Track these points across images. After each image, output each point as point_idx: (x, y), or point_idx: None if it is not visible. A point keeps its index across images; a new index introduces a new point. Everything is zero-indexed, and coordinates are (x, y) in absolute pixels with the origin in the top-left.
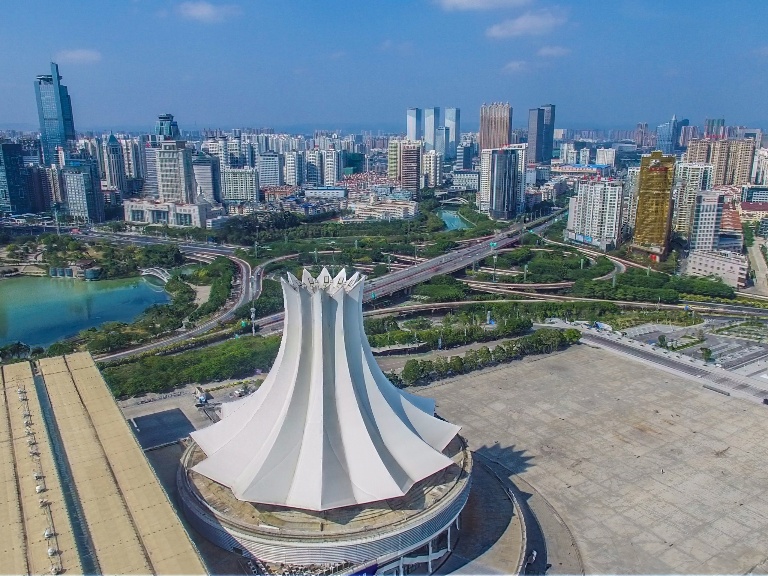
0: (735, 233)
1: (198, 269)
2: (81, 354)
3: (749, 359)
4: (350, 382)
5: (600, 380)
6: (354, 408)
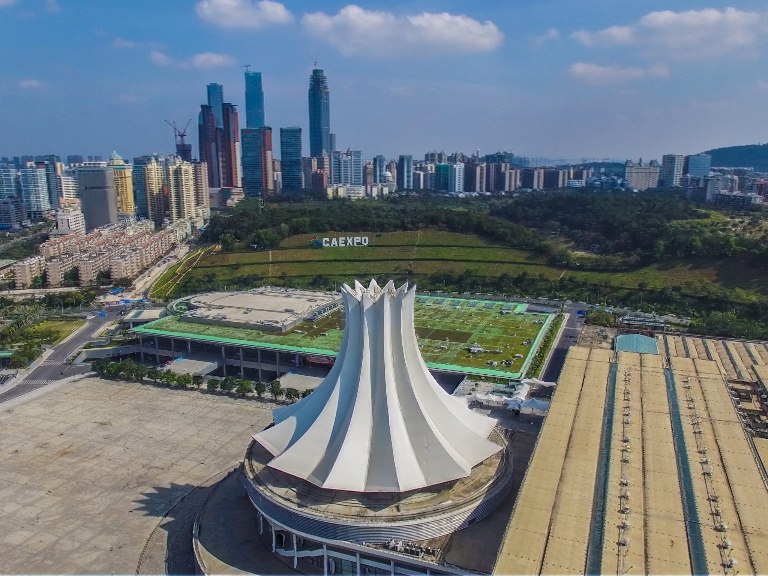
0: None
1: None
2: None
3: None
4: None
5: None
6: None
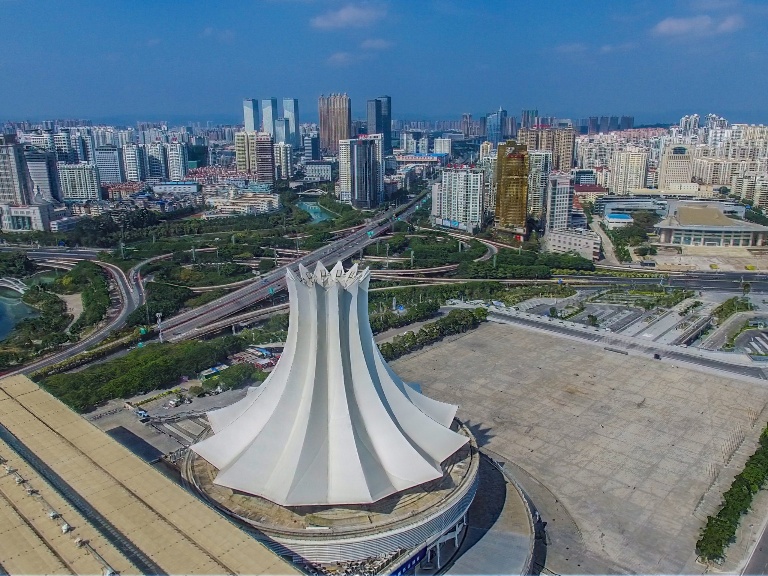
0: (578, 212)
1: (59, 276)
2: (14, 378)
3: (629, 322)
4: (368, 373)
5: (518, 352)
6: (375, 399)
